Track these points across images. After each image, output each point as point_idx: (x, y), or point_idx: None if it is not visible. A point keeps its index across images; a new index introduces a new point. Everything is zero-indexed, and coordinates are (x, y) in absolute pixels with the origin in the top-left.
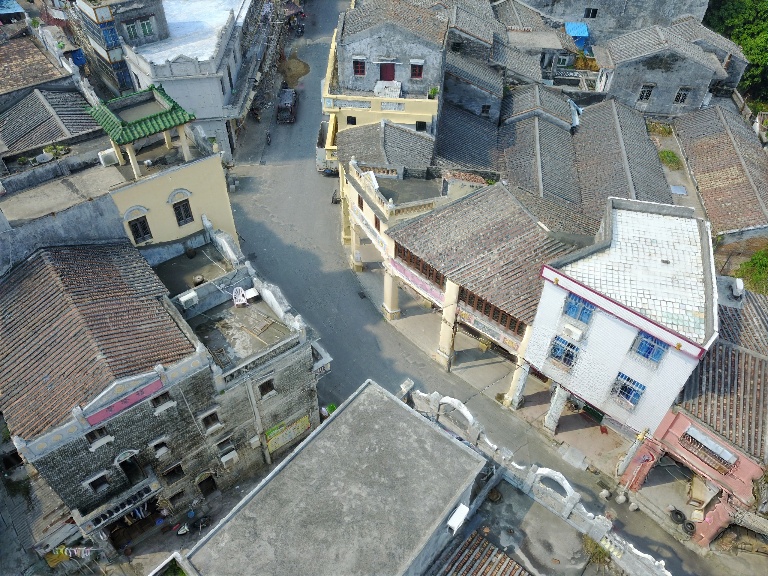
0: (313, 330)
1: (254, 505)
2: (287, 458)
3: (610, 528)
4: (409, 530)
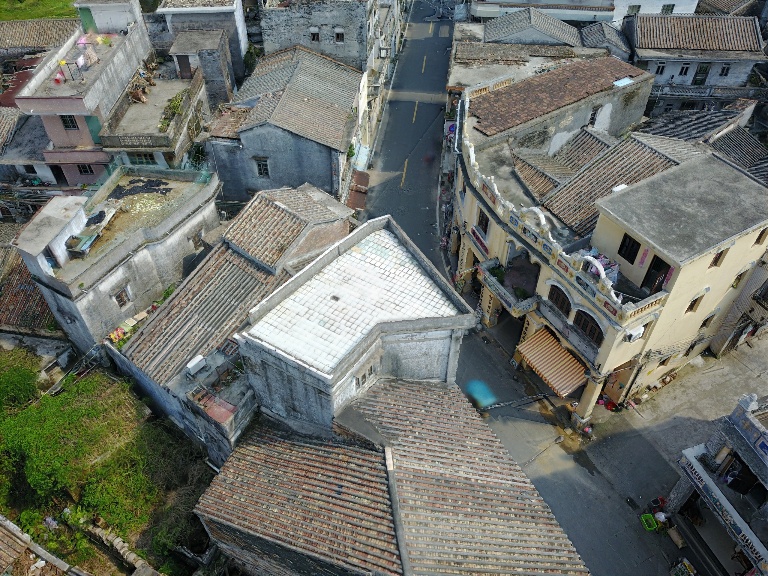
0: (723, 432)
1: (761, 218)
2: (744, 232)
3: (507, 201)
4: (654, 188)
